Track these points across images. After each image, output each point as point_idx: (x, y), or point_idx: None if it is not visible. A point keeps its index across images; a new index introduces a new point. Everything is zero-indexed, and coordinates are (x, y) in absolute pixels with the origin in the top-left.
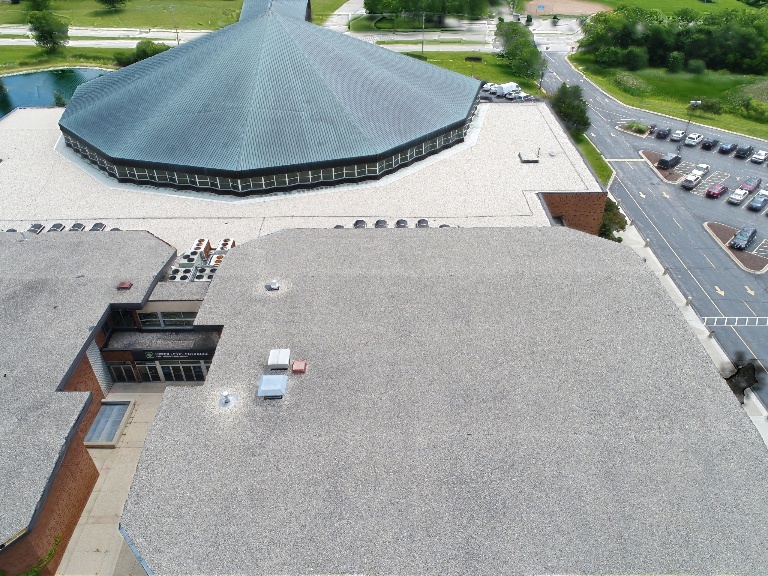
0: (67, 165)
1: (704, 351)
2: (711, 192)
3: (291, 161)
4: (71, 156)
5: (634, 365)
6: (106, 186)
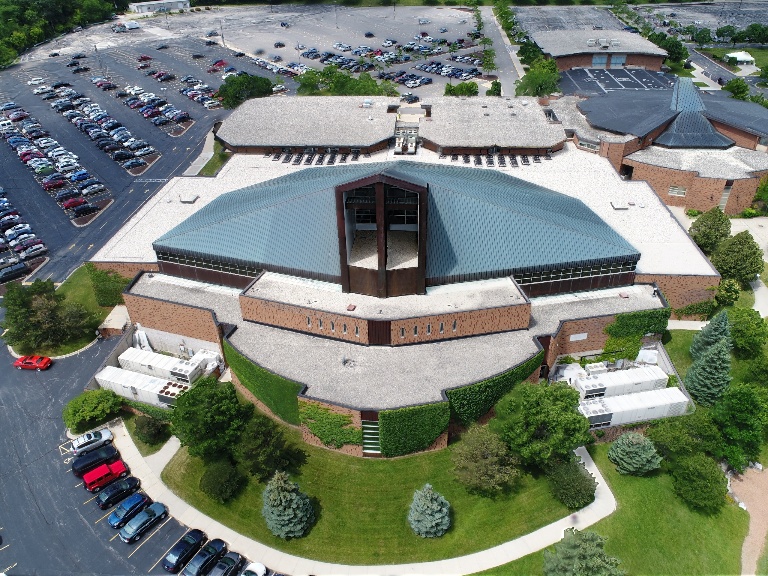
0: None
1: None
2: None
3: None
4: None
5: None
6: None
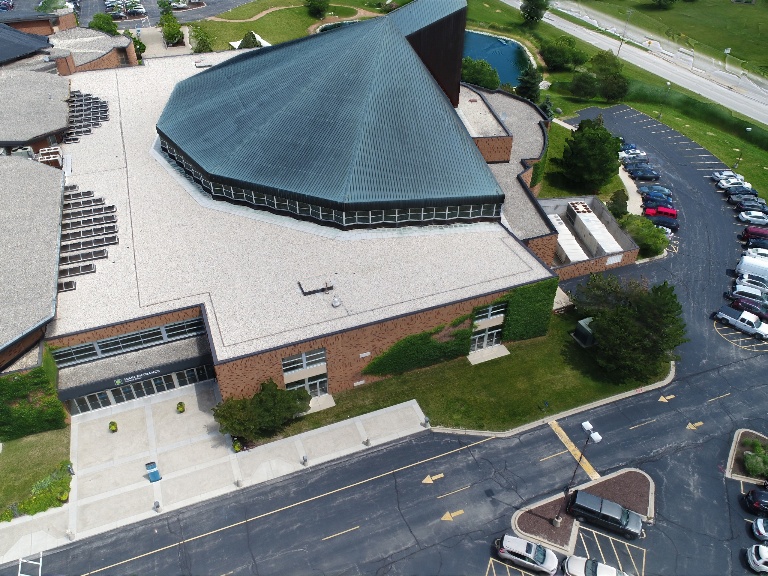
0: None
1: None
2: None
3: (177, 139)
4: None
5: None
6: None
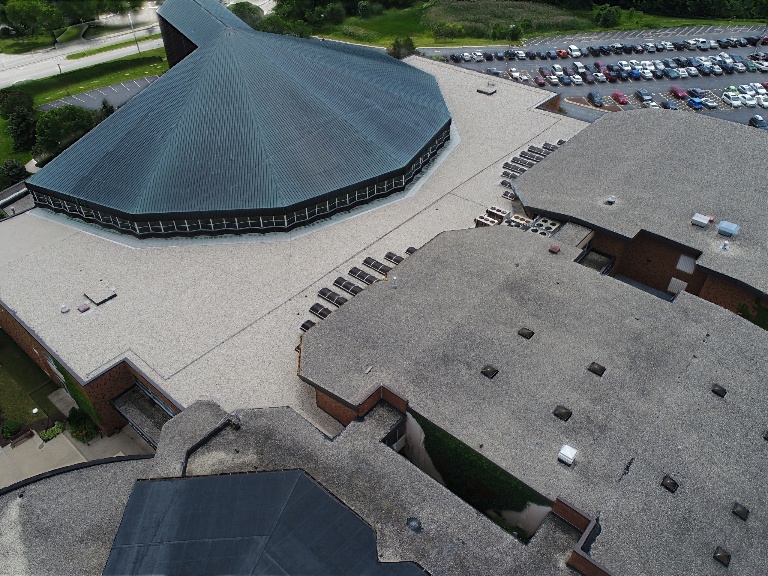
0: (194, 249)
1: None
2: (542, 82)
3: (420, 144)
4: (174, 242)
5: (764, 146)
6: (284, 240)
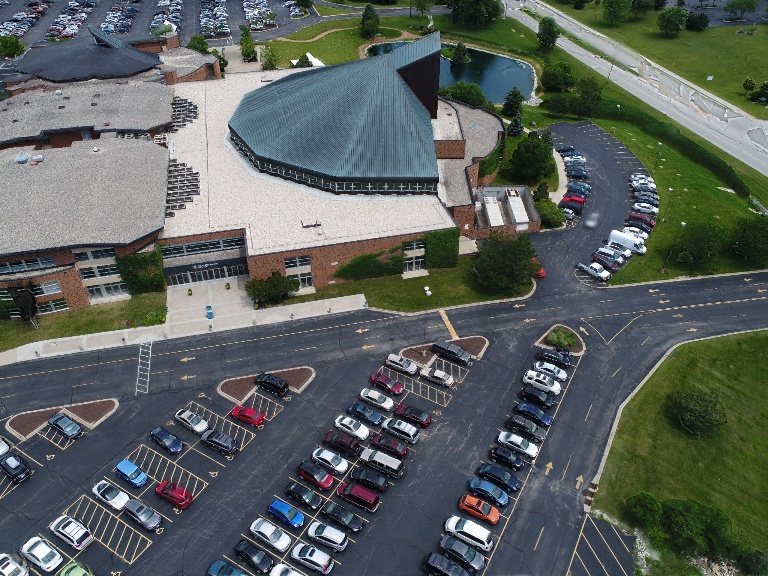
0: None
1: (2, 253)
2: (373, 374)
3: (241, 133)
4: None
5: None
6: None
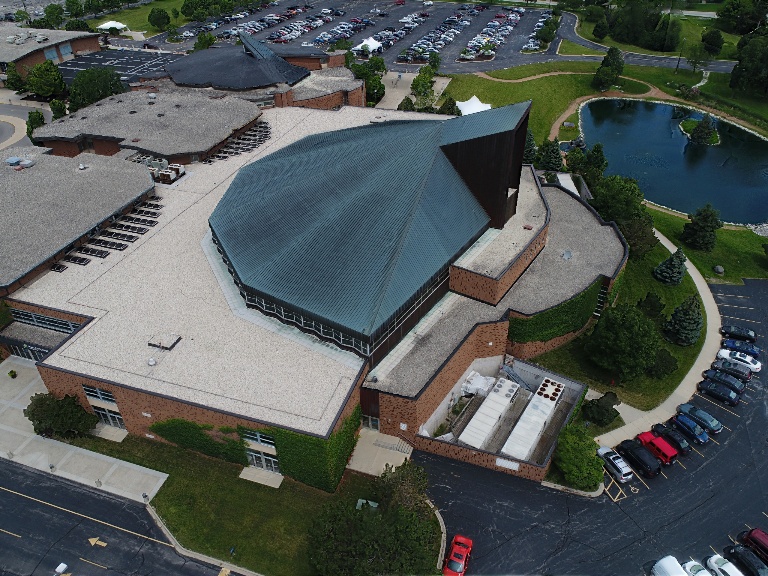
0: None
1: None
2: None
3: (232, 185)
4: None
5: None
6: None
